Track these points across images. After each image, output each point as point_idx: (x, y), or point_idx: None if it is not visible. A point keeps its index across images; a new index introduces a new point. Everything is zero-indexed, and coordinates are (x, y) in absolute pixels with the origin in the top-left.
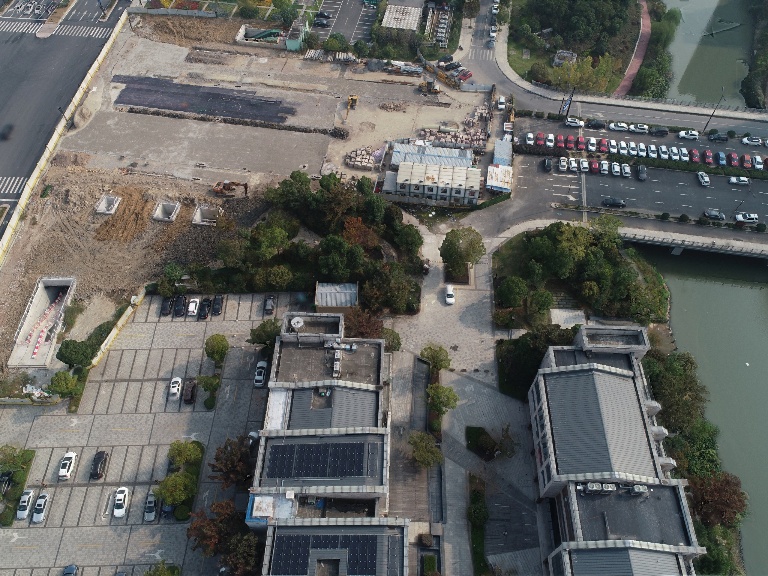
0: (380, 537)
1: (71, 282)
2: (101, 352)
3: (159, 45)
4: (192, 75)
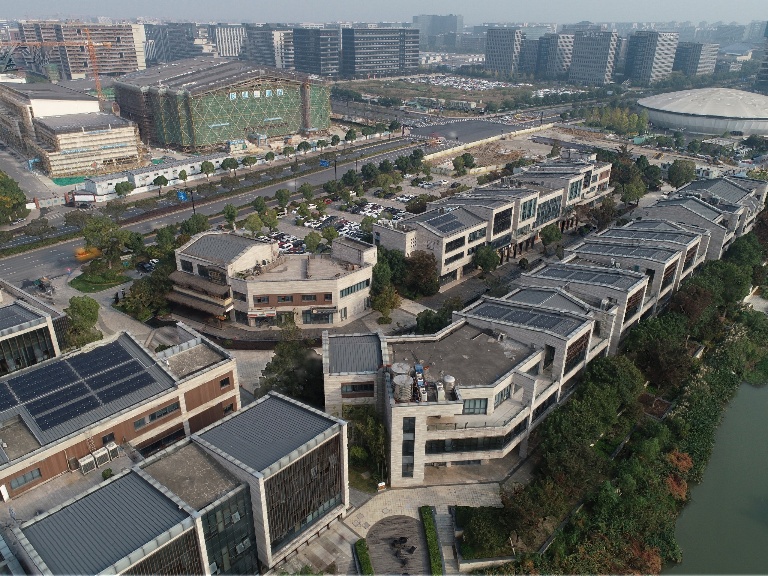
0: (568, 174)
1: (475, 159)
2: (475, 172)
3: (562, 134)
4: (573, 141)
